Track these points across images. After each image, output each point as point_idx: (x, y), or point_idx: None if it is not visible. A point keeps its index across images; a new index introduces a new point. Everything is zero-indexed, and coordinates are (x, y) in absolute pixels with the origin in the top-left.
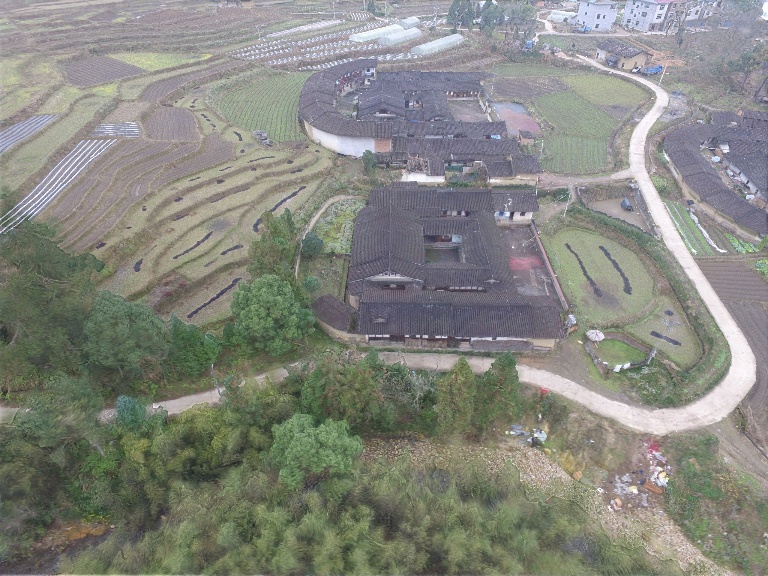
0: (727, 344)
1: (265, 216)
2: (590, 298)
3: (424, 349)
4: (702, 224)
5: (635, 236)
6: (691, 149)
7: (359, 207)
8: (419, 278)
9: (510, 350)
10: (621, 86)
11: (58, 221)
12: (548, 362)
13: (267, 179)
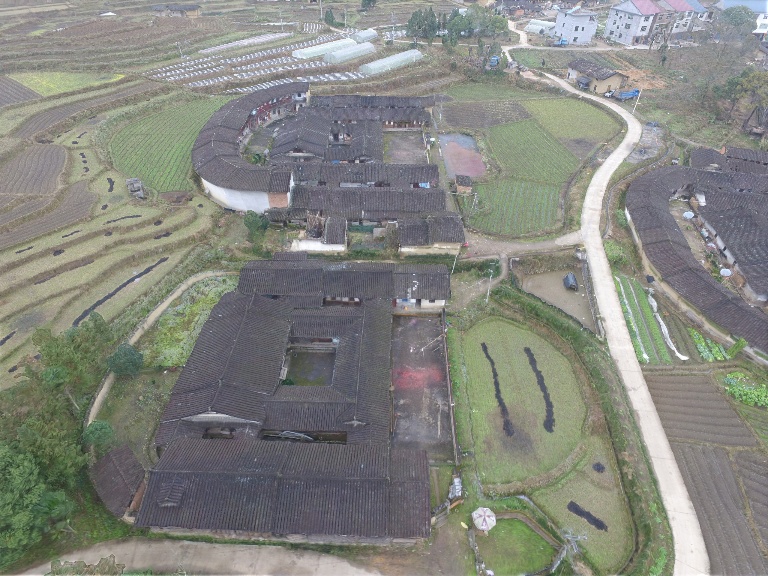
0: (670, 537)
1: (37, 337)
2: (496, 438)
3: (239, 539)
4: (662, 312)
5: (570, 336)
6: (657, 204)
7: (228, 288)
8: (254, 419)
9: (360, 543)
10: (590, 114)
11: None
12: (411, 564)
13: (121, 248)
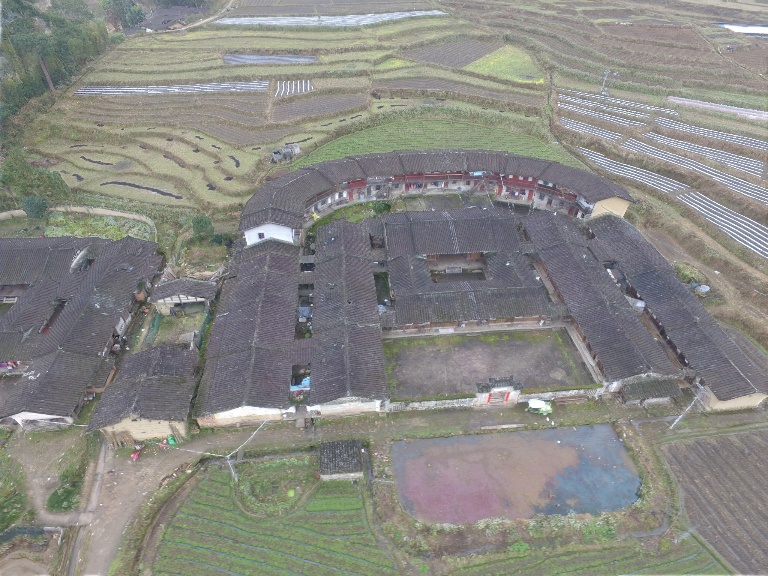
0: None
1: None
2: None
3: None
4: None
5: None
6: None
7: None
8: None
9: None
10: None
11: (125, 102)
12: None
13: (198, 173)
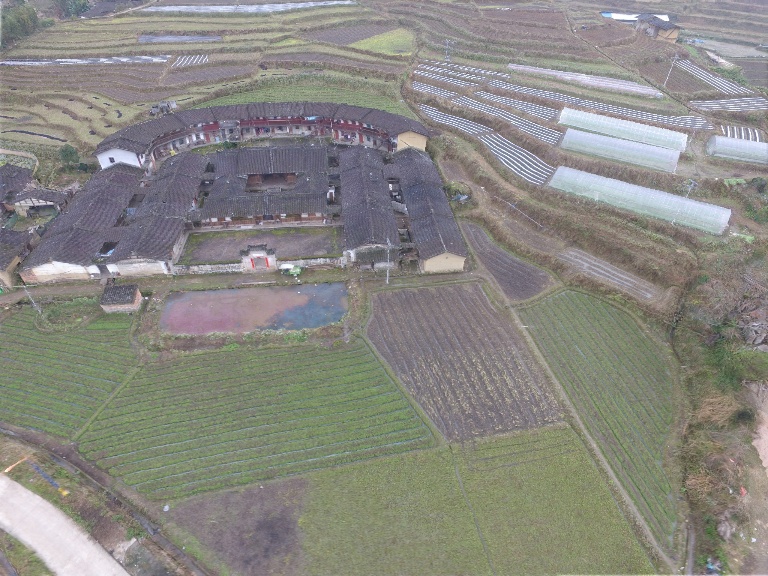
0: None
1: None
2: None
3: None
4: None
5: None
6: None
7: None
8: None
9: None
10: None
11: (38, 71)
12: None
13: (86, 123)
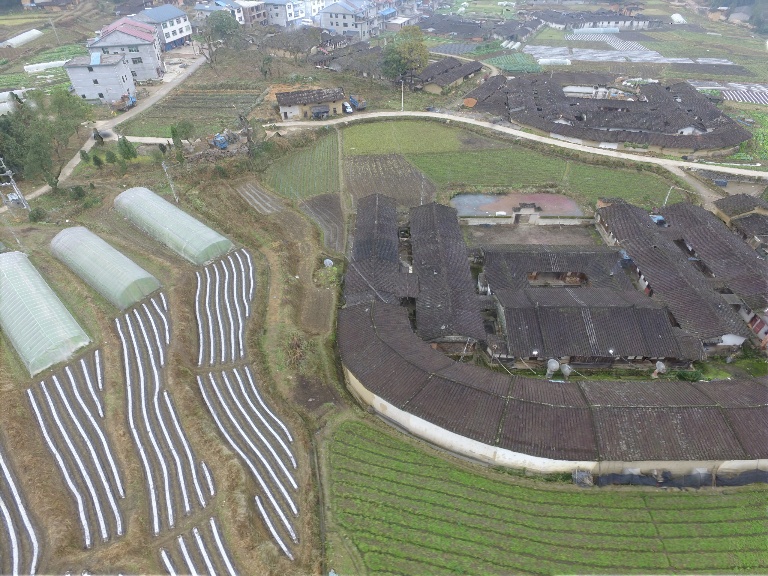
0: None
1: None
2: None
3: None
4: (718, 162)
5: None
6: None
7: None
8: None
9: None
10: (393, 127)
11: None
12: None
13: None
